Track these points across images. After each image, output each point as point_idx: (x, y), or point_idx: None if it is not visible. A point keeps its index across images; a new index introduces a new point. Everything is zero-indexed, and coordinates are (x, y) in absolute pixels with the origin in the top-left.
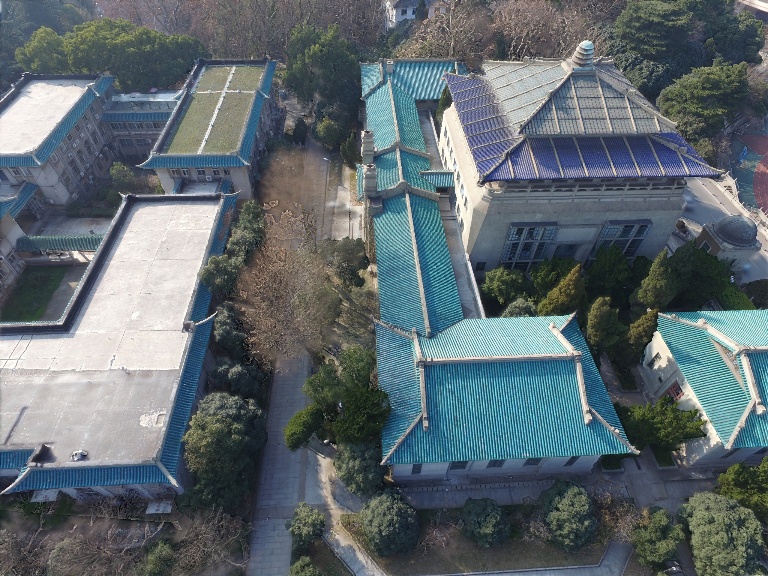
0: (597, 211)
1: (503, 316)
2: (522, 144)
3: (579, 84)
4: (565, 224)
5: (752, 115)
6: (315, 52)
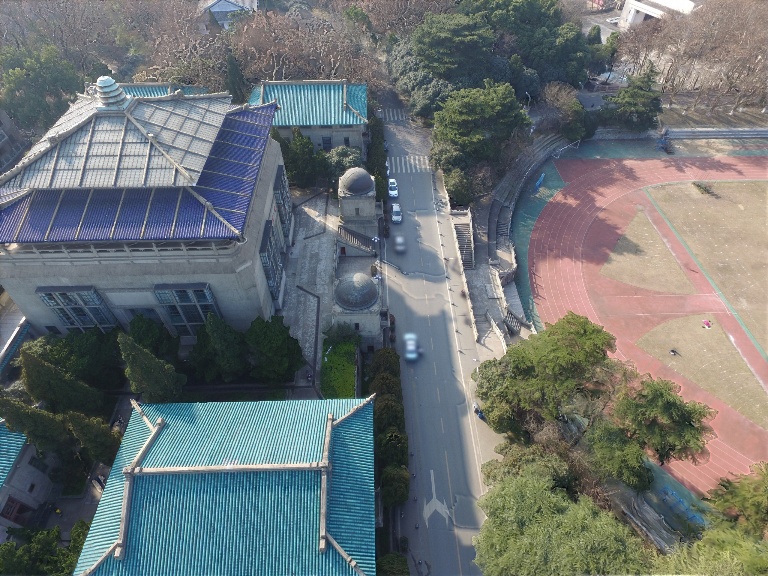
0: (132, 274)
1: None
2: (25, 198)
3: (101, 127)
4: (107, 288)
5: (567, 137)
6: (17, 76)
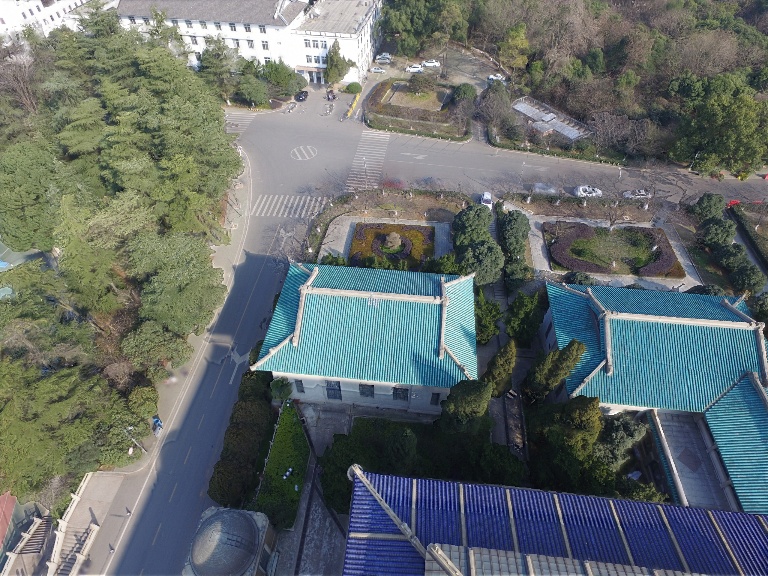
0: None
1: (648, 424)
2: None
3: None
4: None
5: None
6: None
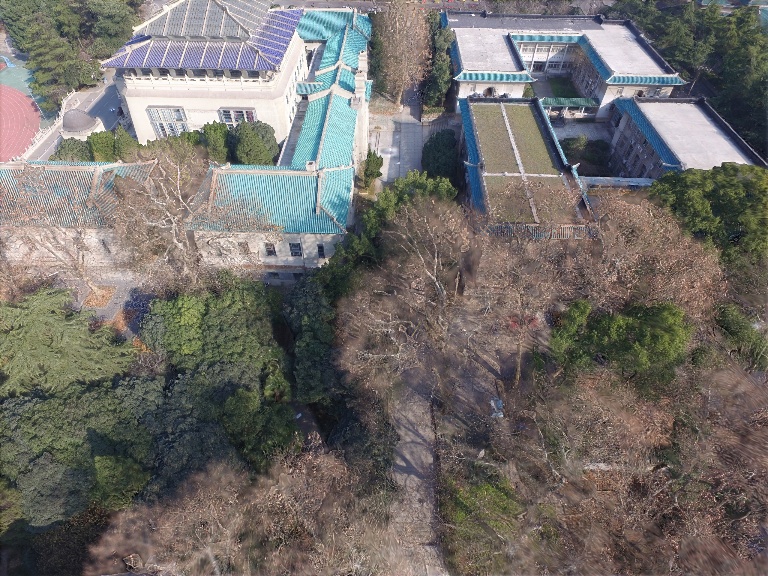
0: None
1: None
2: None
3: None
4: None
5: None
6: None
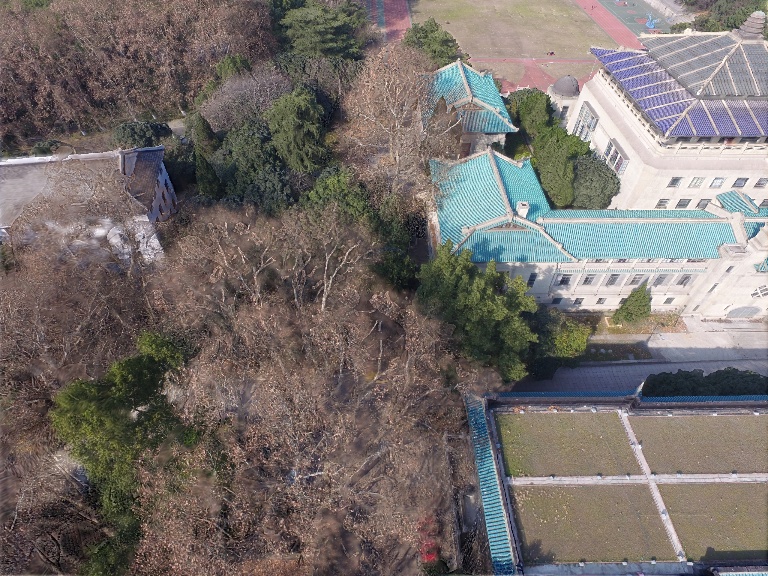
0: None
1: None
2: None
3: None
4: None
5: None
6: None
